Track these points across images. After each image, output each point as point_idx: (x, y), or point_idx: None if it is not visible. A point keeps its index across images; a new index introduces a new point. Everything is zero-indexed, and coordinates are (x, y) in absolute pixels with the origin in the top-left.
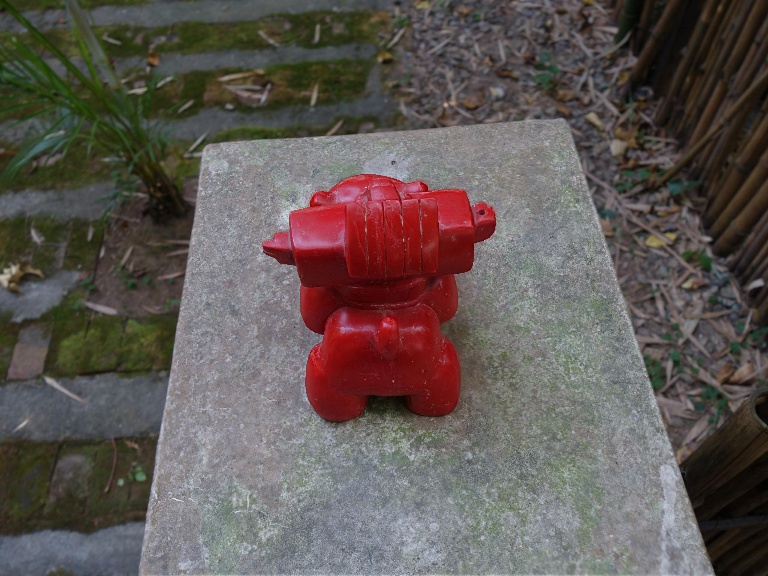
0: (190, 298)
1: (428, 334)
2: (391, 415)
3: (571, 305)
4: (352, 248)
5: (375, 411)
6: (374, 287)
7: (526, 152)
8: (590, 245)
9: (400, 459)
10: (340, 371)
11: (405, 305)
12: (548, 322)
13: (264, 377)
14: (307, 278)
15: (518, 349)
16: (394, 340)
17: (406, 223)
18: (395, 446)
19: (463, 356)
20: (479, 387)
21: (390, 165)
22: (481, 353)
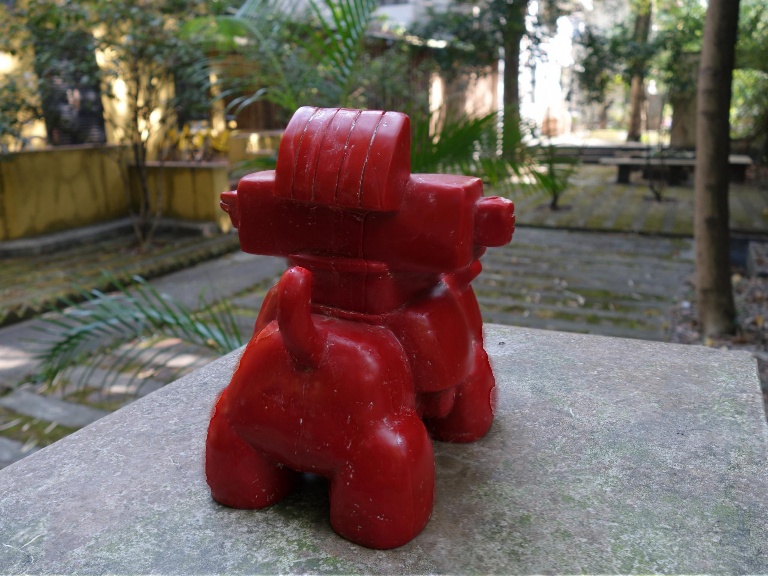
0: (194, 376)
1: (374, 361)
2: (301, 524)
3: (676, 500)
4: (283, 149)
5: (284, 513)
6: (317, 258)
7: (680, 365)
8: (742, 453)
9: (265, 574)
10: (241, 385)
11: (360, 317)
12: (624, 506)
13: (191, 443)
14: (244, 229)
15: (553, 519)
16: (292, 291)
17: (357, 129)
18: (273, 557)
19: (459, 500)
20: (457, 538)
21: (496, 344)
22: (489, 505)
